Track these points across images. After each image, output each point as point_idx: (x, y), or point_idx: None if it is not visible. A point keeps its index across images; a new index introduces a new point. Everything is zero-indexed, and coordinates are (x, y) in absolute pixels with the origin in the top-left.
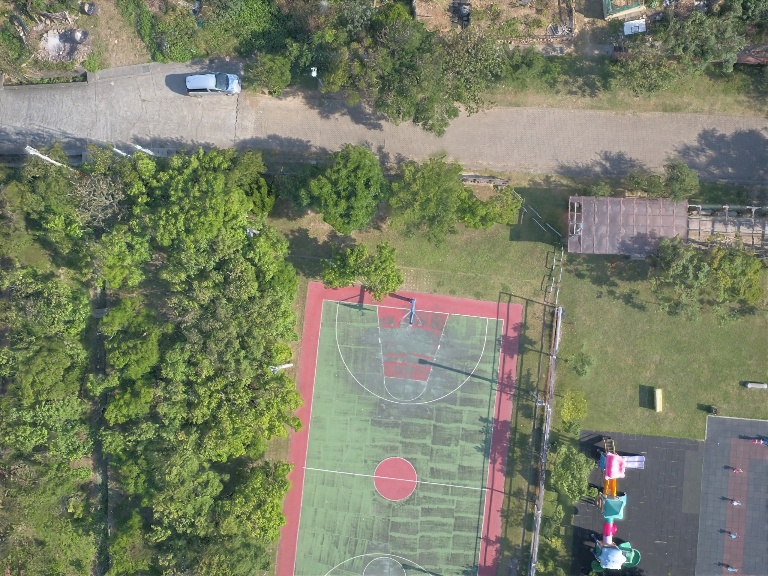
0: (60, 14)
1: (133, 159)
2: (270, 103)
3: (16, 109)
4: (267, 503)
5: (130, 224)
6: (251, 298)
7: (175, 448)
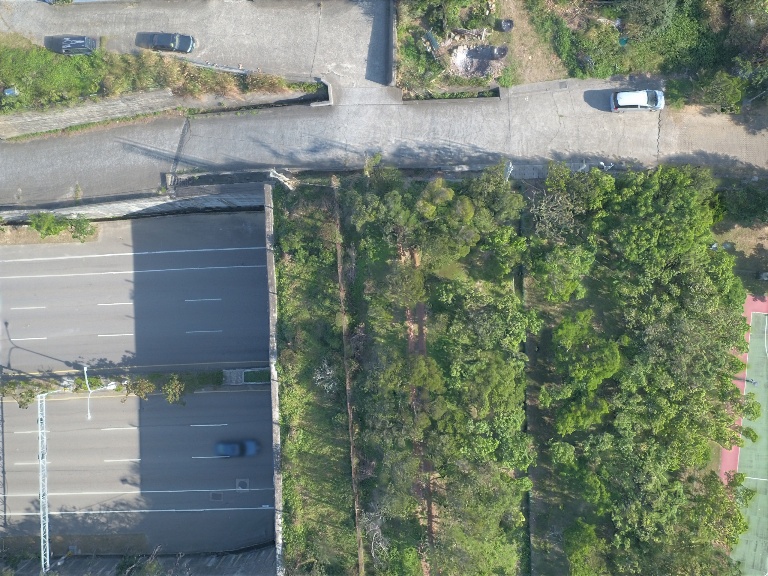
0: (477, 30)
1: (594, 175)
2: (694, 119)
3: (417, 123)
4: (736, 512)
5: (584, 239)
6: (714, 311)
7: (626, 458)
